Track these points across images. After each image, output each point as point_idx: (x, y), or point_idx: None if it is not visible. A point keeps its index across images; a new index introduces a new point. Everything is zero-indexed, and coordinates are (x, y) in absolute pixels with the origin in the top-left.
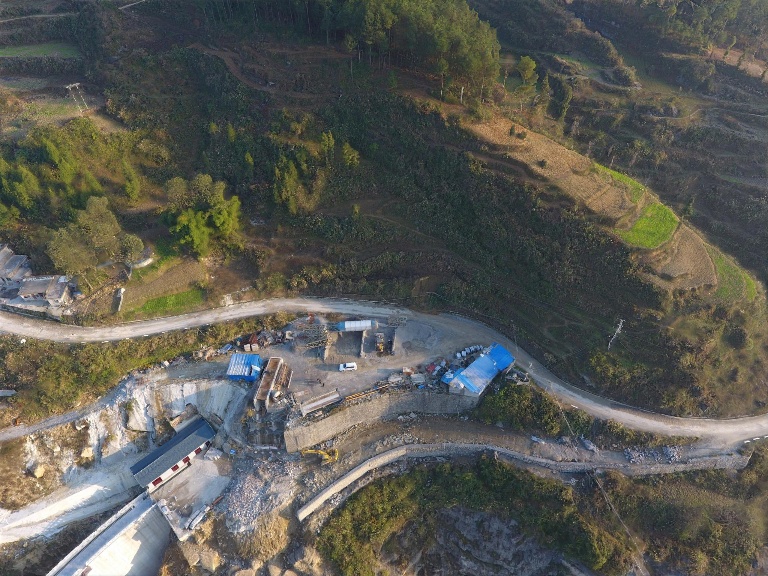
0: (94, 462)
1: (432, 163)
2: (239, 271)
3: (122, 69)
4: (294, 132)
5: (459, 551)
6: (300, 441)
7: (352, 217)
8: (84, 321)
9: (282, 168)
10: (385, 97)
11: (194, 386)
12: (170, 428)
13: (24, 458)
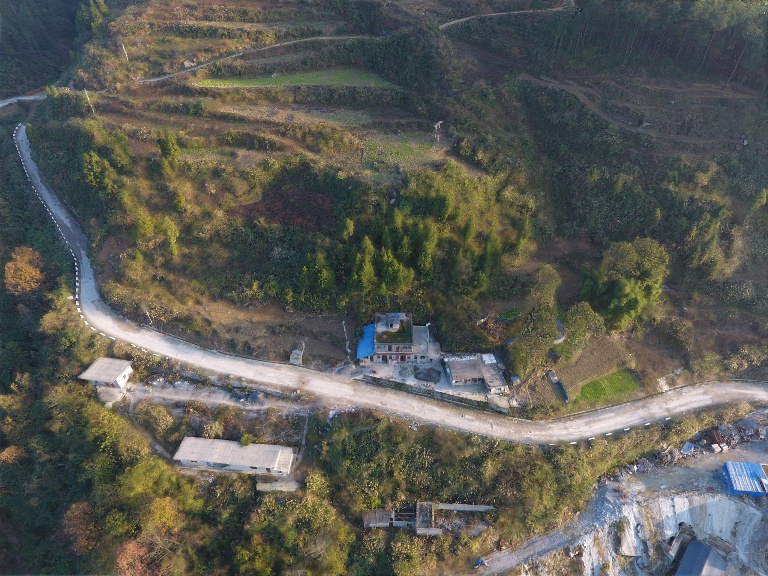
0: None
1: None
2: (654, 347)
3: (464, 103)
4: (697, 183)
5: None
6: None
7: None
8: (536, 414)
9: (700, 227)
10: None
11: (686, 501)
12: (661, 552)
13: None
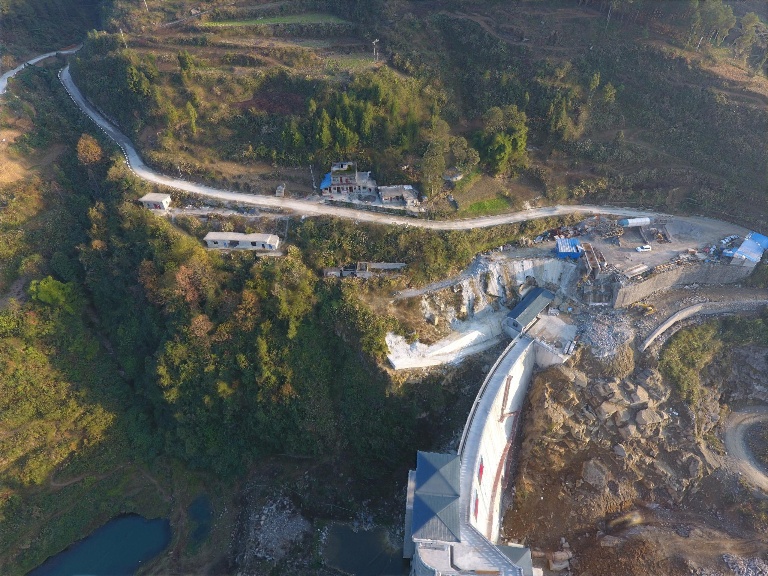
0: (468, 316)
1: (676, 98)
2: (525, 186)
3: (397, 30)
4: (557, 77)
5: (751, 379)
6: (625, 299)
7: (618, 141)
8: (436, 216)
9: (556, 104)
10: (635, 47)
11: (531, 262)
12: (515, 294)
13: (422, 311)
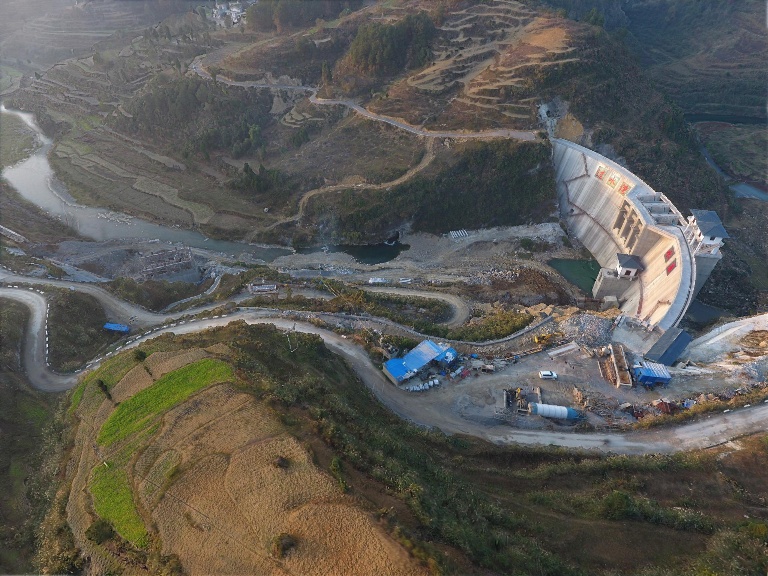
0: None
1: None
2: (759, 487)
3: None
4: None
5: None
6: None
7: None
8: None
9: None
10: None
11: (690, 371)
12: None
13: None
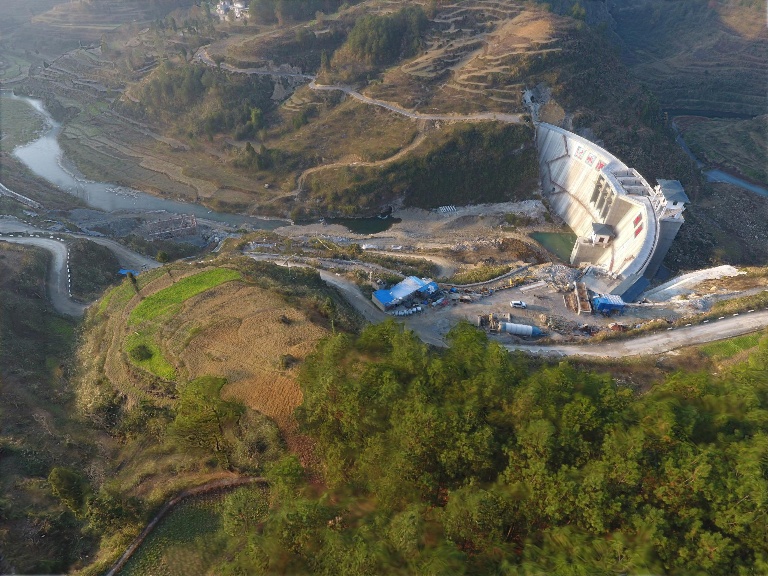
0: None
1: None
2: None
3: None
4: None
5: None
6: None
7: None
8: None
9: None
10: None
11: None
12: None
13: None
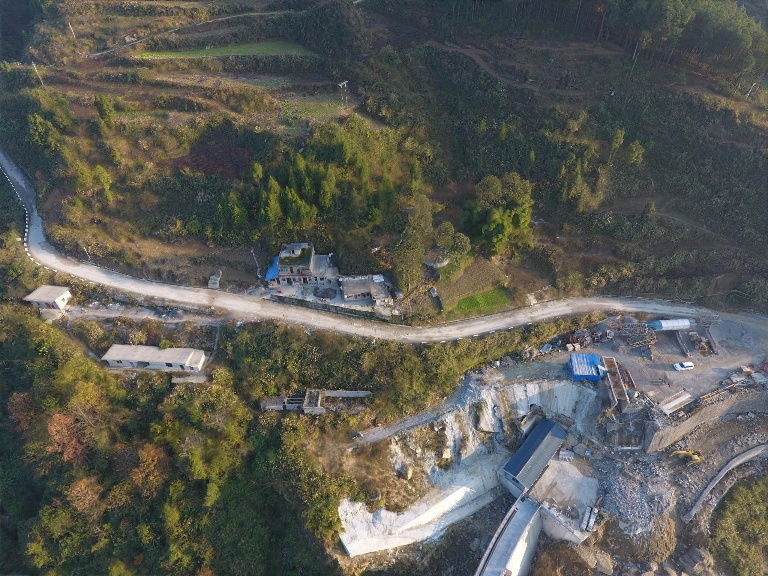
0: (453, 463)
1: (720, 160)
2: (529, 270)
3: (372, 67)
4: (569, 130)
5: None
6: (662, 441)
7: (647, 215)
8: (414, 321)
9: (568, 166)
10: (669, 94)
11: (537, 386)
12: (515, 429)
13: (391, 460)
